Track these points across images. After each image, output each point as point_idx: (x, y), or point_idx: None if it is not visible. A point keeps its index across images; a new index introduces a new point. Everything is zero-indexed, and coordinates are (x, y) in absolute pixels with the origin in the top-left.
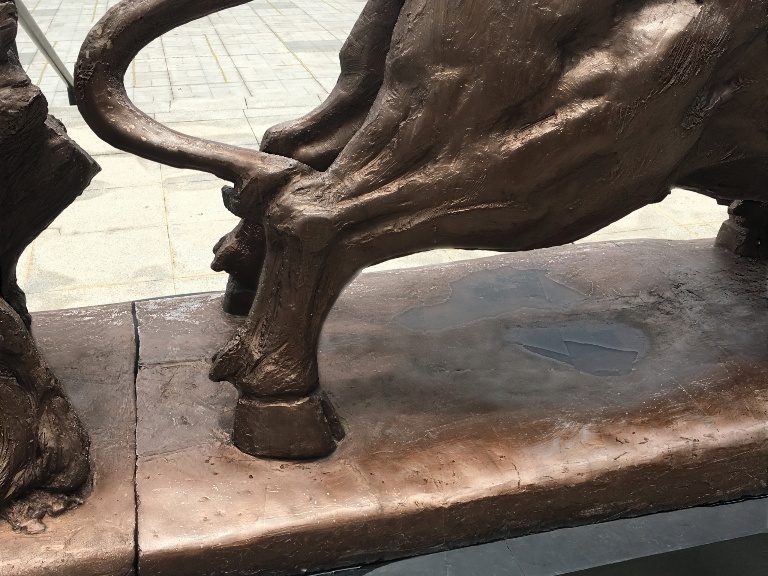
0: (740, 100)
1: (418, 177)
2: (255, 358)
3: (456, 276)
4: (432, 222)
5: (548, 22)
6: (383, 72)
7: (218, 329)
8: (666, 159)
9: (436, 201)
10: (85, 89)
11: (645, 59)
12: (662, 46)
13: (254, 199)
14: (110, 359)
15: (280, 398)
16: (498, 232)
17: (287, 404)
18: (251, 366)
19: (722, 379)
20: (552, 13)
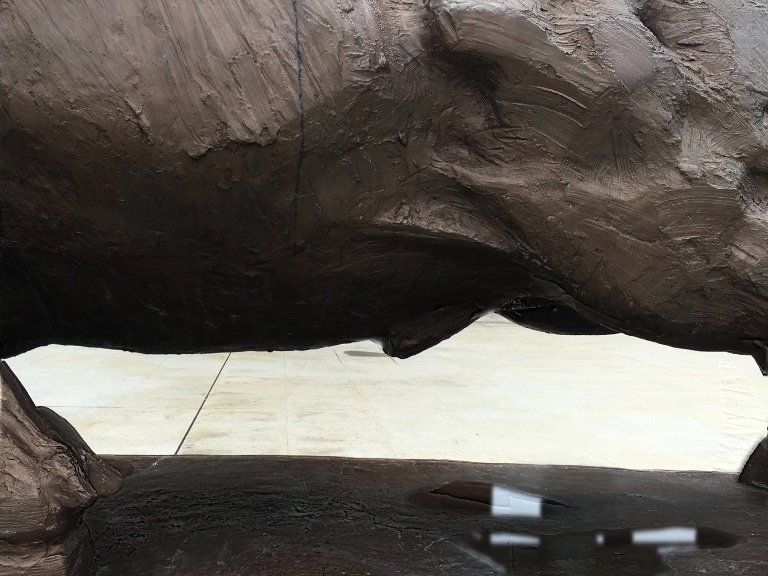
0: None
1: None
2: None
3: None
4: None
5: None
6: None
7: None
8: None
9: None
10: None
11: None
12: None
13: None
14: None
15: None
16: None
17: None
18: None
19: (371, 462)
20: None
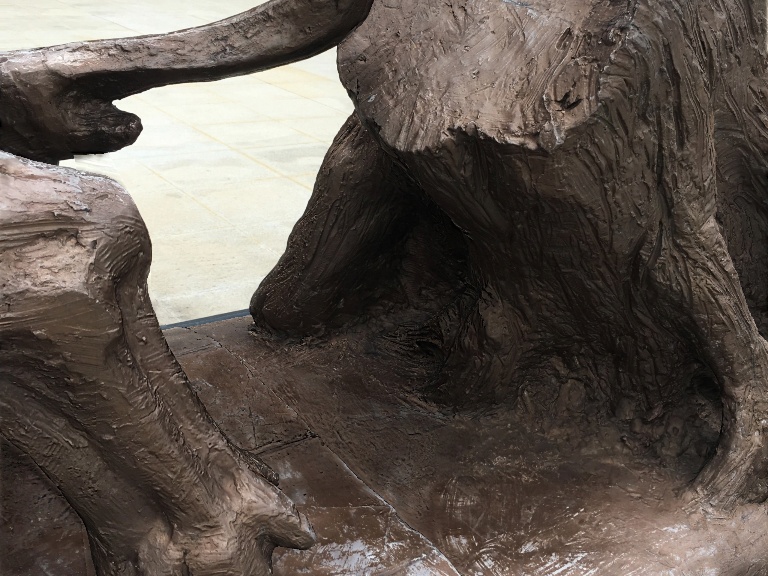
0: None
1: None
2: None
3: None
4: None
5: None
6: None
7: None
8: None
9: None
10: None
11: None
12: None
13: None
14: (386, 464)
15: None
16: None
17: None
18: None
19: None
20: None
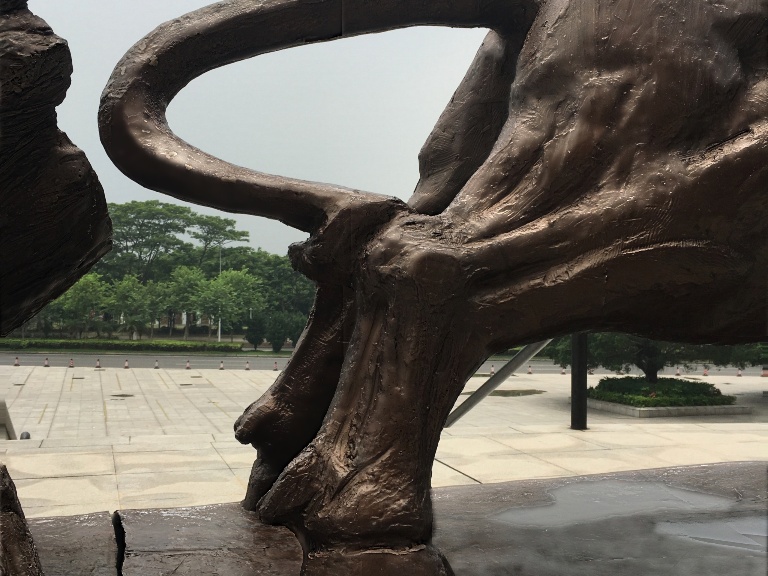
0: None
1: (575, 209)
2: (340, 474)
3: (551, 485)
4: (601, 268)
5: (726, 20)
6: (482, 158)
7: (240, 524)
8: None
9: (604, 238)
10: (114, 110)
11: None
12: None
13: (343, 240)
14: (78, 554)
15: (381, 541)
16: (691, 289)
17: (393, 550)
18: (333, 489)
19: None
20: (730, 11)
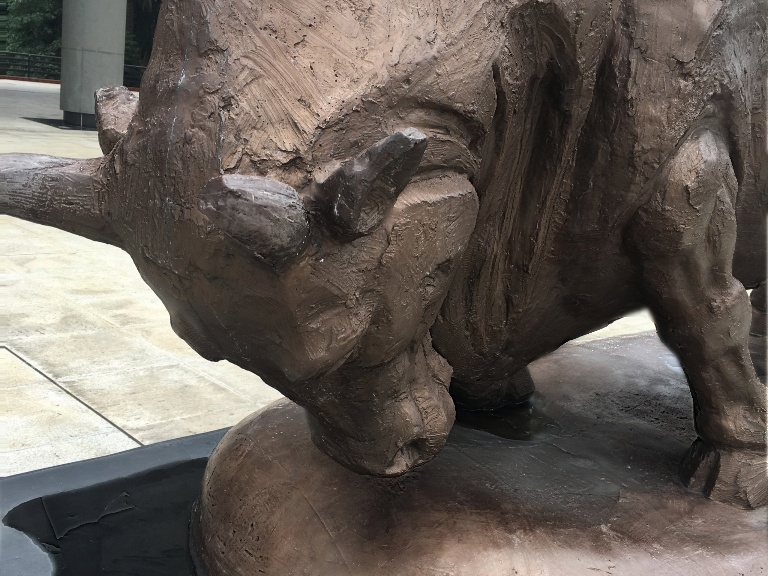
0: None
1: None
2: None
3: None
4: None
5: None
6: None
7: None
8: None
9: None
10: None
11: None
12: None
13: None
14: None
15: None
16: None
17: None
18: None
19: (605, 348)
20: None
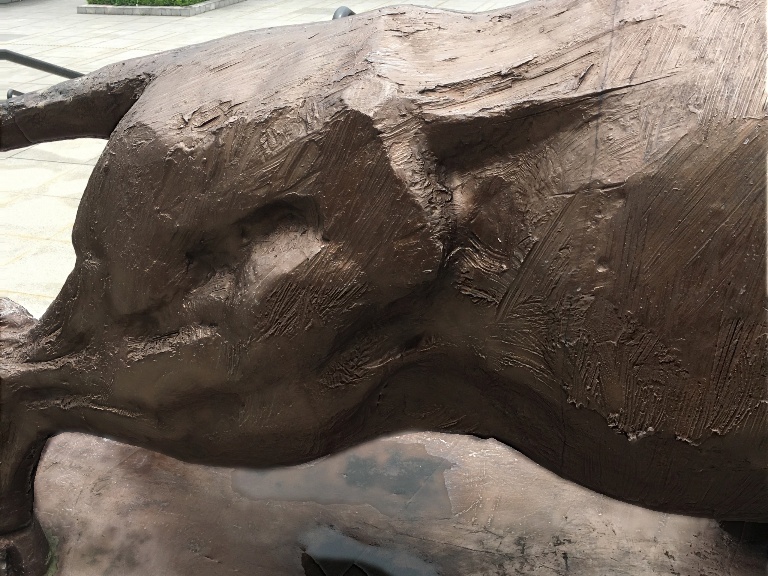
0: (445, 362)
1: (74, 360)
2: None
3: None
4: (80, 410)
5: (168, 230)
6: None
7: None
8: (301, 416)
9: (82, 390)
10: None
11: (243, 297)
12: (262, 286)
13: None
14: None
15: None
16: None
17: None
18: None
19: None
20: (172, 221)
